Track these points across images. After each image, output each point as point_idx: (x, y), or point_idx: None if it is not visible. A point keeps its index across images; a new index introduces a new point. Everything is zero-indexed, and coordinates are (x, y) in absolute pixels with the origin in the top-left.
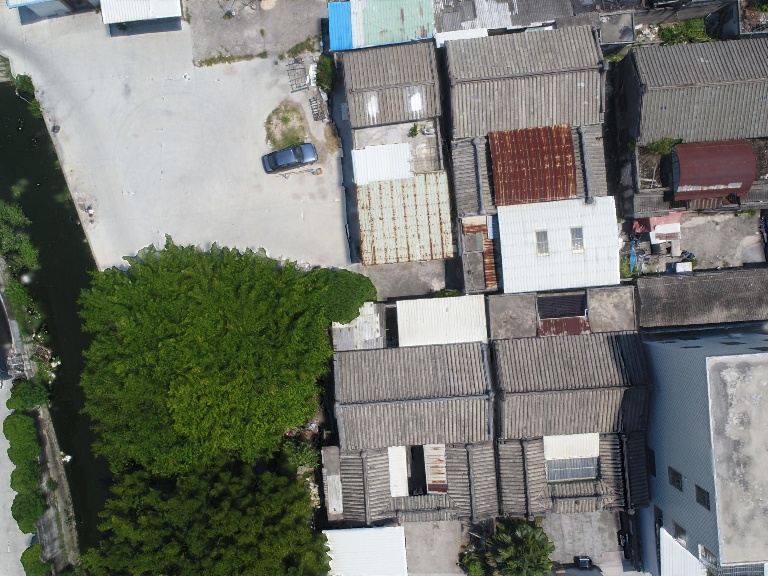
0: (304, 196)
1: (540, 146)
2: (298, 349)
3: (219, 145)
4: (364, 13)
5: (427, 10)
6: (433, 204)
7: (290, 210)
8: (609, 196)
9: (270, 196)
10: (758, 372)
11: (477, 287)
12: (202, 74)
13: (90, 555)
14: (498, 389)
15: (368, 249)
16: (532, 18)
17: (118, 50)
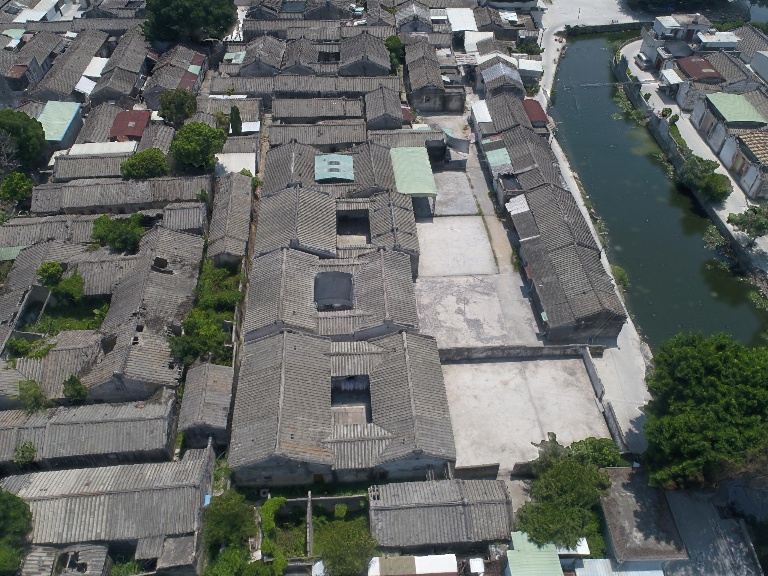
0: None
1: None
2: None
3: None
4: None
5: None
6: None
7: None
8: None
9: None
10: None
11: None
12: None
13: None
14: None
15: None
16: None
17: None
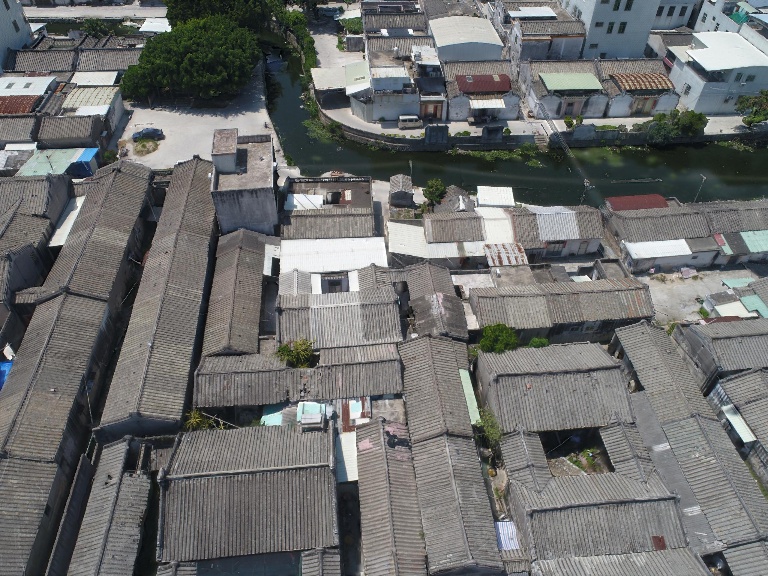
0: None
1: (6, 107)
2: None
3: None
4: (71, 158)
5: None
6: None
7: None
8: None
9: None
10: None
11: None
12: None
13: (251, 2)
14: (77, 55)
15: None
16: None
17: None
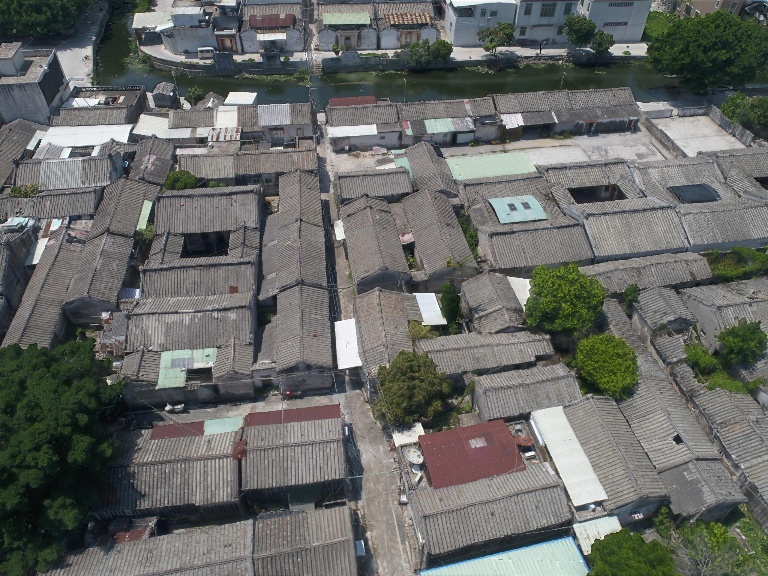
0: None
1: None
2: None
3: None
4: None
5: None
6: None
7: None
8: None
9: None
10: None
11: None
12: None
13: None
14: None
15: None
16: None
17: None
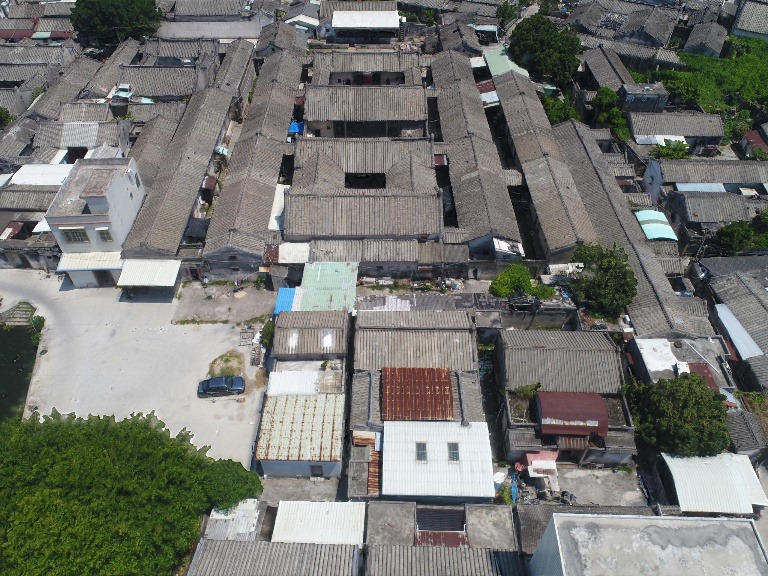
0: (224, 417)
1: (423, 379)
2: (164, 497)
3: (167, 374)
4: (304, 295)
5: (349, 297)
6: (329, 415)
7: (208, 427)
8: (483, 422)
9: (195, 414)
10: (609, 534)
11: (359, 493)
12: (175, 329)
13: None
14: None
15: (263, 445)
16: (426, 308)
17: (119, 310)
